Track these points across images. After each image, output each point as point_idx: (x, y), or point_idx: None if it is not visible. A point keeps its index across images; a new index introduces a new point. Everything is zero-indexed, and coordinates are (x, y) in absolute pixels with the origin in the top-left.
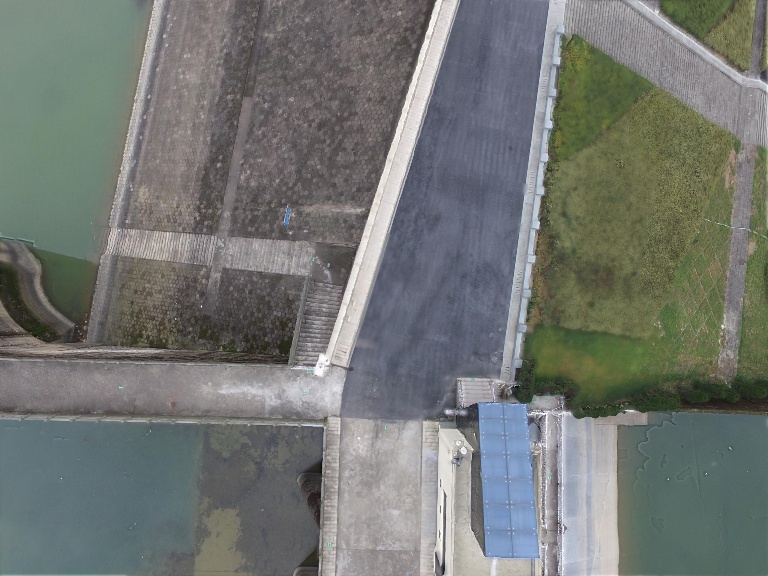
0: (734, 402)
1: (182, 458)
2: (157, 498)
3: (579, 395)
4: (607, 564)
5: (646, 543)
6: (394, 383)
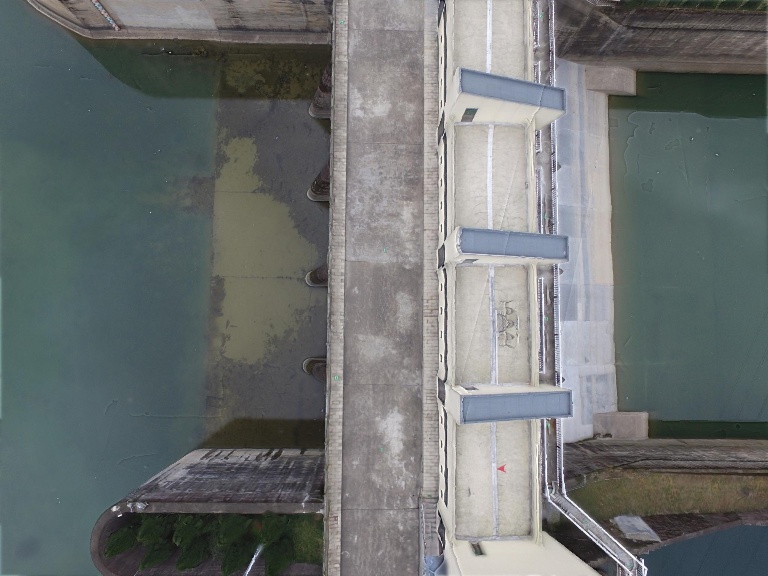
0: (713, 5)
1: (201, 95)
2: (178, 131)
3: None
4: (600, 216)
5: (637, 211)
6: None
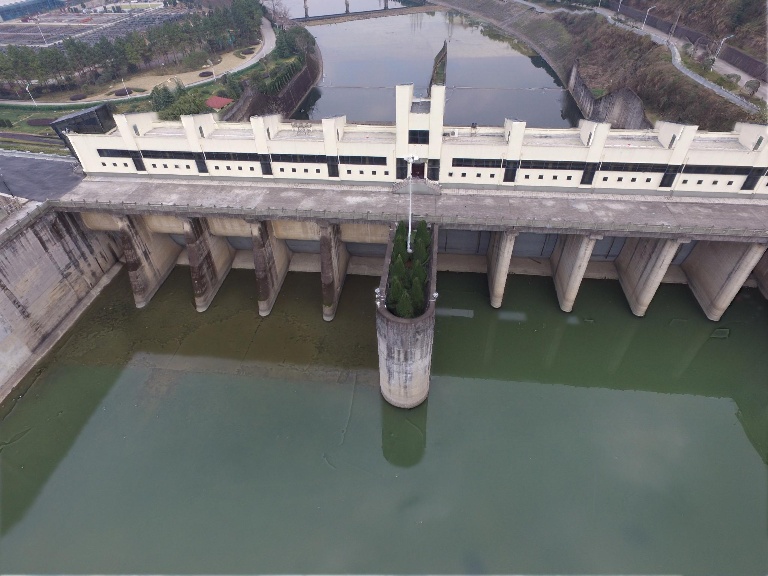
0: None
1: None
2: (96, 395)
3: None
4: None
5: None
6: (55, 188)
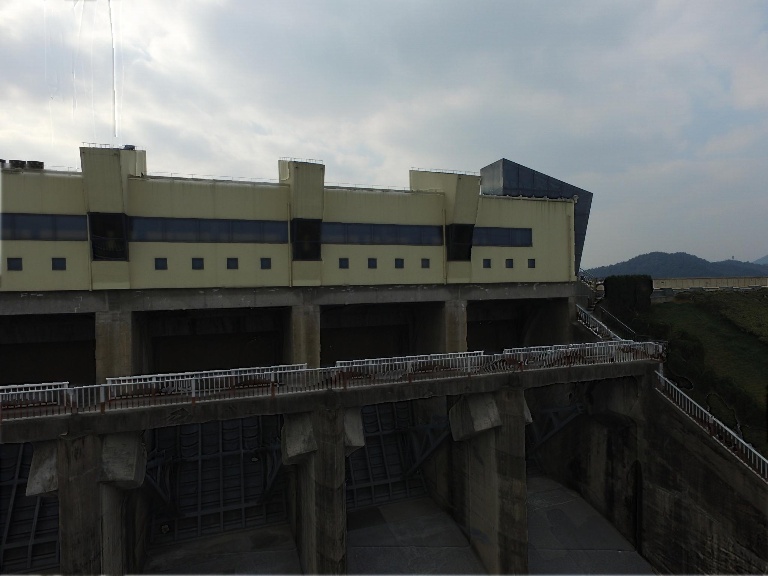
0: None
1: None
2: None
3: (692, 343)
4: None
5: None
6: None
